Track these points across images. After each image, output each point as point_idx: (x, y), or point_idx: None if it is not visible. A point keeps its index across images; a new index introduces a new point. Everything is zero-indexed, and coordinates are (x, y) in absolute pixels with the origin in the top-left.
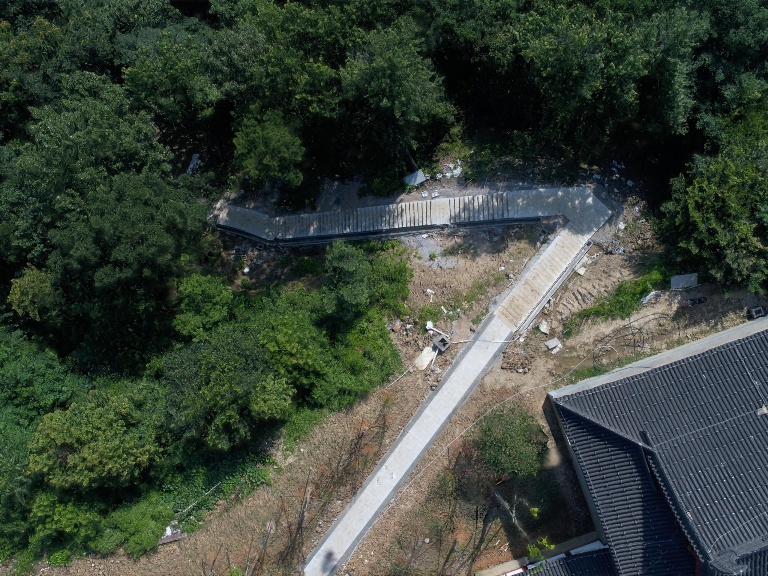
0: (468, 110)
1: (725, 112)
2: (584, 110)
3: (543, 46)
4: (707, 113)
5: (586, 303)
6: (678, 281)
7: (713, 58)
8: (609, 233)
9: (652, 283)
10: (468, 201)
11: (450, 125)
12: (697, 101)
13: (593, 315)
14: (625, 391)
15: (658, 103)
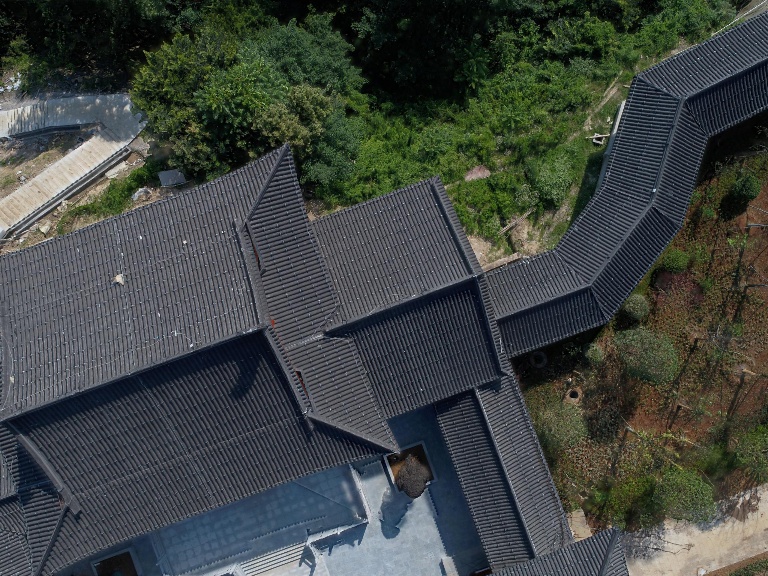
0: (32, 24)
1: None
2: (45, 2)
3: None
4: (194, 9)
5: (87, 203)
6: (166, 177)
7: None
8: None
9: (133, 178)
10: (21, 112)
11: (8, 38)
12: None
13: (85, 213)
14: (1, 266)
15: None
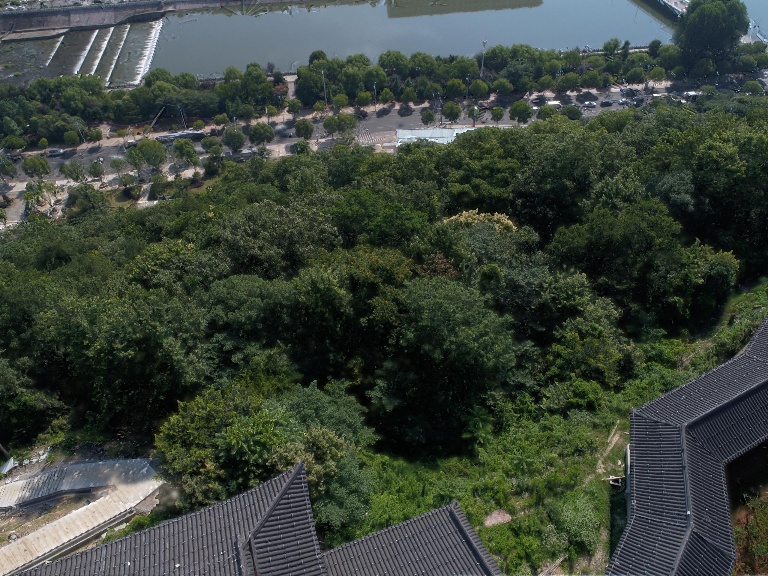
0: (78, 408)
1: (243, 377)
2: (101, 372)
3: (46, 315)
4: (228, 379)
5: None
6: None
7: (228, 336)
8: (158, 502)
9: (133, 527)
10: (37, 480)
11: (52, 418)
12: (222, 371)
13: None
14: None
15: (174, 368)
